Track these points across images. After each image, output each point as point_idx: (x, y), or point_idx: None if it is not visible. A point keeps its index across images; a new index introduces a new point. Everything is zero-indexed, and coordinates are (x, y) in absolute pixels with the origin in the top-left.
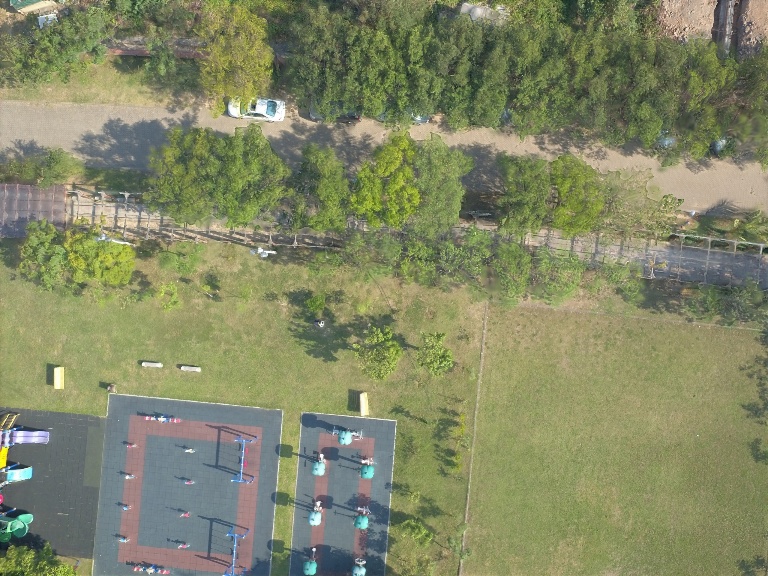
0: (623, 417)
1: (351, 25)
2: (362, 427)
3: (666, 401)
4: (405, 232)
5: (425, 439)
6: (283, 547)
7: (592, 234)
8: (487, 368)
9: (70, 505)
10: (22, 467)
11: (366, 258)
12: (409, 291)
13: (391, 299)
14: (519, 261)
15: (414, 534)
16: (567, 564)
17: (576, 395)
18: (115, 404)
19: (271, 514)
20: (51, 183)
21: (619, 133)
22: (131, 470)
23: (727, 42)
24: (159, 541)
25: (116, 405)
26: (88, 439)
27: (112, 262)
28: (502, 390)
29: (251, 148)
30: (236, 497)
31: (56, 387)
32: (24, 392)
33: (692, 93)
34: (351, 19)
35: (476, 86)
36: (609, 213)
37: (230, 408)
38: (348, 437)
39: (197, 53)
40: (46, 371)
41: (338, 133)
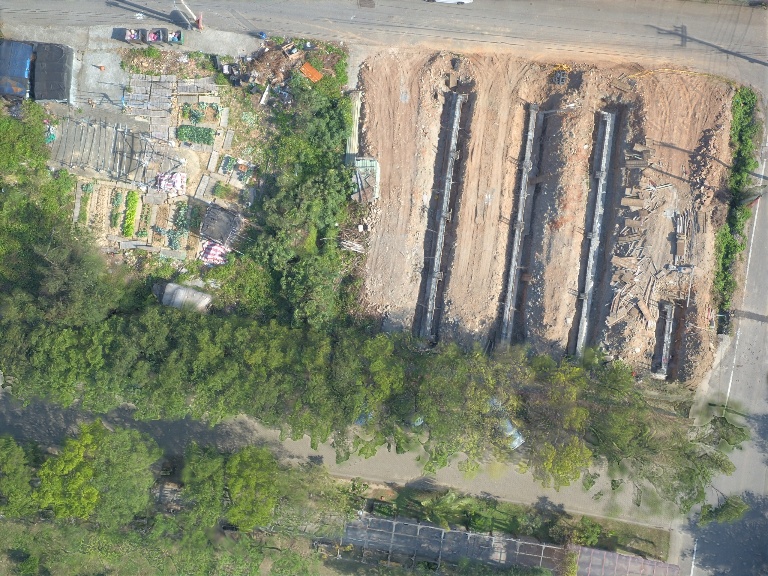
0: None
1: None
2: None
3: None
4: (94, 517)
5: None
6: None
7: None
8: None
9: None
10: None
11: (48, 549)
12: None
13: (105, 559)
14: (191, 558)
15: None
16: None
17: None
18: None
19: None
20: None
21: (297, 429)
22: None
23: (428, 319)
24: None
25: None
26: None
27: None
28: None
29: None
30: None
31: None
32: None
33: (355, 403)
34: (47, 308)
35: (155, 386)
36: (276, 515)
37: None
38: None
39: None
40: None
41: (57, 396)
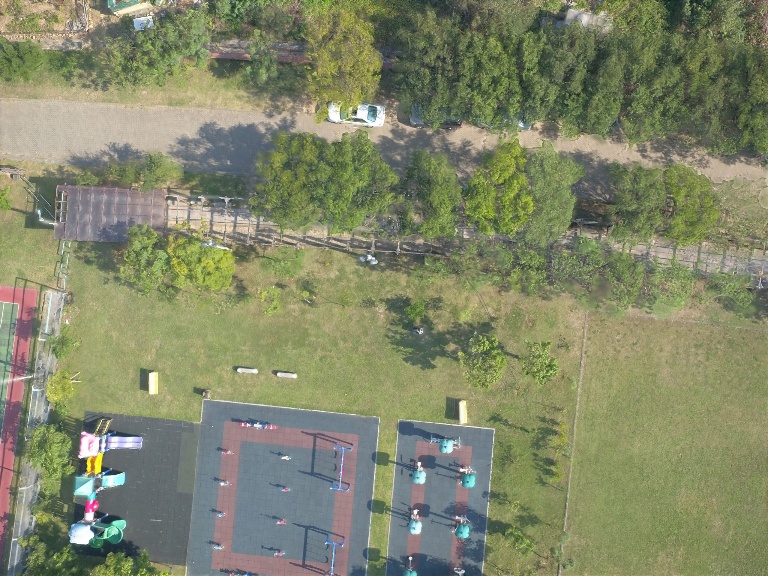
0: (724, 427)
1: (460, 31)
2: (460, 435)
3: (767, 412)
4: (514, 240)
5: (524, 448)
6: (379, 555)
7: (695, 243)
8: (587, 377)
9: (163, 511)
10: (115, 473)
11: (477, 266)
12: (508, 299)
13: (490, 307)
14: (633, 270)
15: (517, 544)
16: (667, 575)
17: (677, 405)
18: (209, 410)
19: (367, 522)
20: (152, 187)
21: (732, 142)
22: (225, 477)
23: None
24: (253, 548)
25: (210, 411)
26: (182, 445)
27: (214, 267)
28: (602, 399)
29: (358, 154)
30: (332, 505)
31: (151, 392)
32: (117, 397)
33: None
34: (460, 25)
35: (590, 93)
36: (725, 223)
37: (326, 415)
38: (450, 446)
39: (295, 57)
40: (139, 376)
41: (437, 139)
